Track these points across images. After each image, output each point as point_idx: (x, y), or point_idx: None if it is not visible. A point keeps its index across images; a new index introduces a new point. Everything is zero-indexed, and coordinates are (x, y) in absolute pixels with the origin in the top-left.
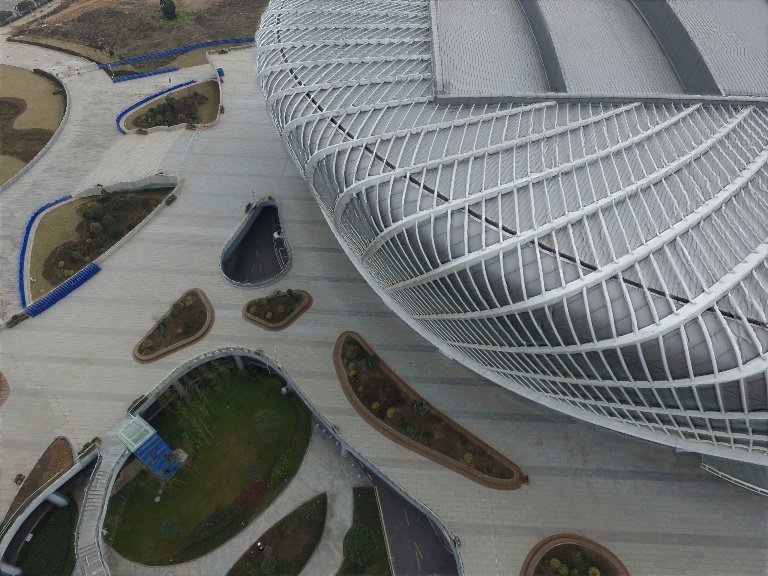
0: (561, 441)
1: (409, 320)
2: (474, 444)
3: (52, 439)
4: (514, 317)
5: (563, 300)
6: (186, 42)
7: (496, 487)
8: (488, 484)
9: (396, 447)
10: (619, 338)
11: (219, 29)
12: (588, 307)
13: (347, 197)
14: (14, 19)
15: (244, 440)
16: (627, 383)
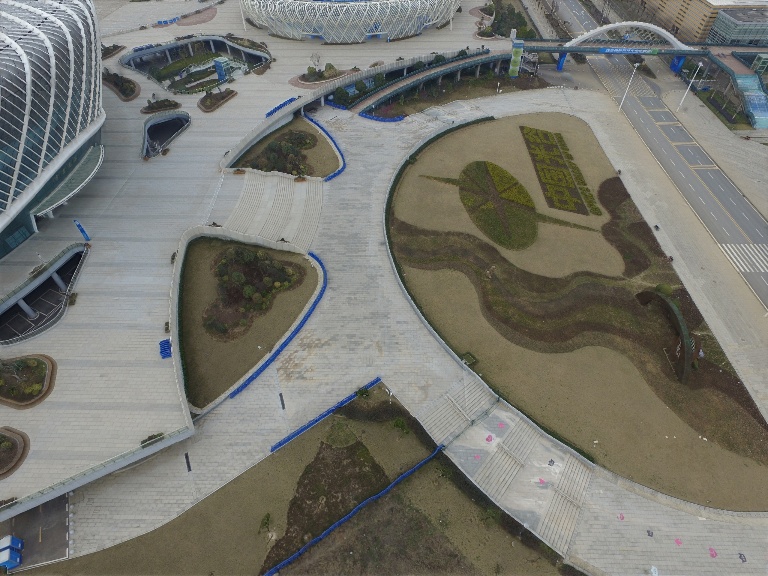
0: None
1: None
2: None
3: None
4: None
5: None
6: None
7: None
8: None
9: None
10: None
11: None
12: None
13: None
14: None
15: None
16: None
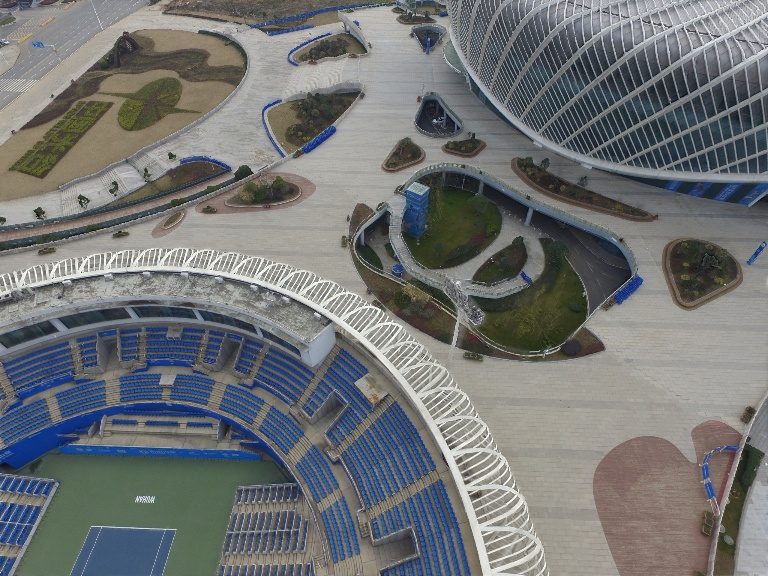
0: (673, 203)
1: (558, 148)
2: (619, 203)
3: (355, 204)
4: (669, 76)
5: (703, 52)
6: (309, 9)
7: (638, 221)
8: (633, 220)
9: (569, 206)
10: (735, 67)
11: None
12: (718, 52)
13: (557, 31)
14: None
15: (461, 217)
16: (734, 107)
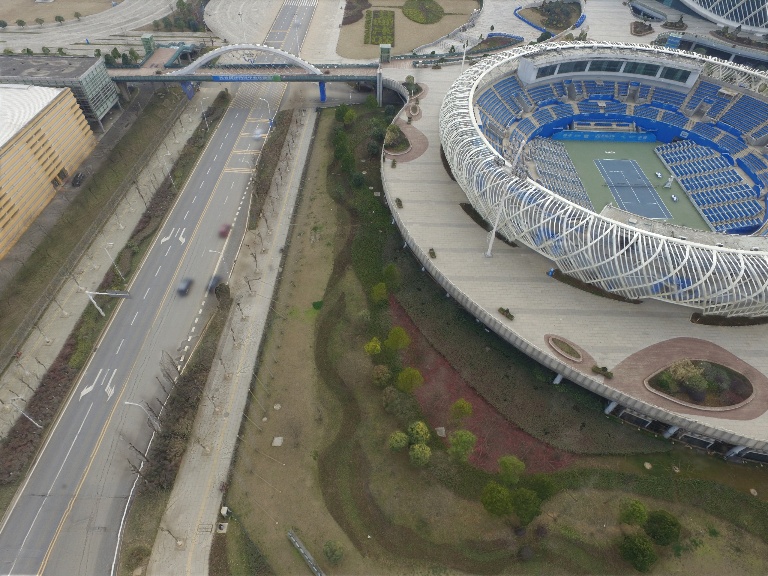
0: None
1: (738, 25)
2: None
3: None
4: None
5: None
6: None
7: None
8: None
9: None
10: None
11: None
12: None
13: None
14: None
15: None
16: None
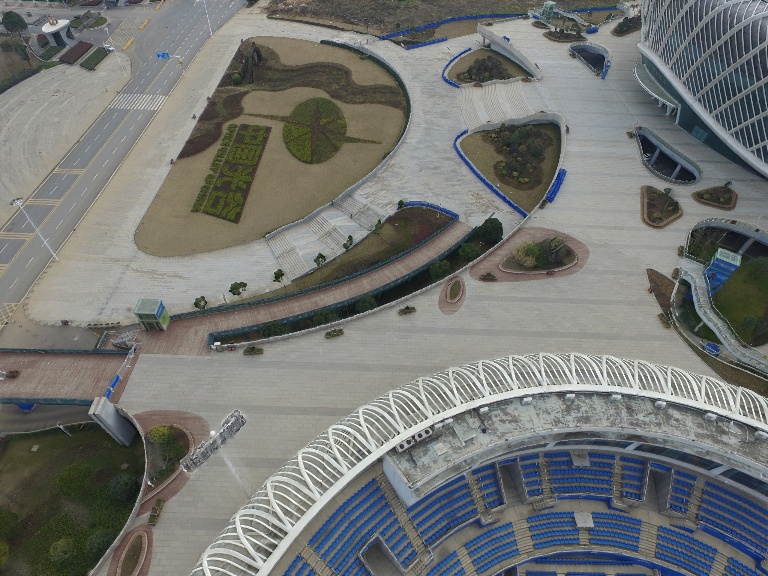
0: None
1: None
2: None
3: (644, 270)
4: None
5: None
6: (431, 18)
7: None
8: None
9: None
10: None
11: (450, 8)
12: None
13: None
14: (255, 1)
15: (740, 280)
16: None
